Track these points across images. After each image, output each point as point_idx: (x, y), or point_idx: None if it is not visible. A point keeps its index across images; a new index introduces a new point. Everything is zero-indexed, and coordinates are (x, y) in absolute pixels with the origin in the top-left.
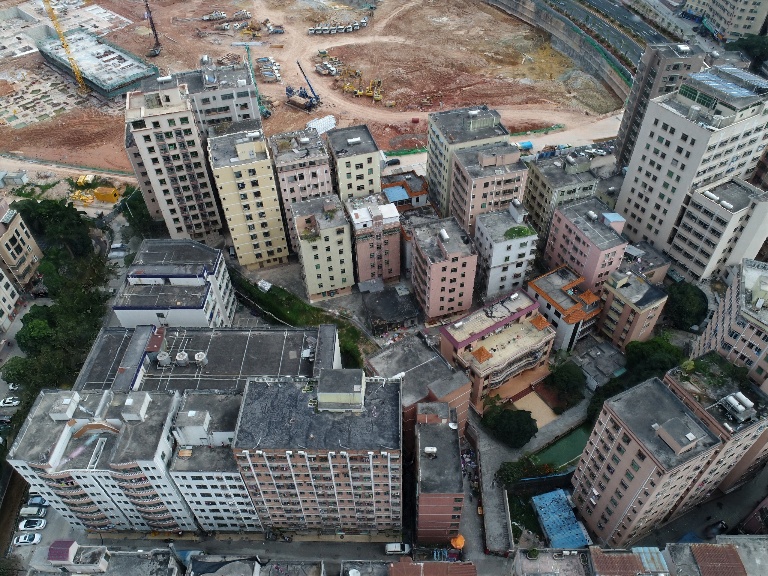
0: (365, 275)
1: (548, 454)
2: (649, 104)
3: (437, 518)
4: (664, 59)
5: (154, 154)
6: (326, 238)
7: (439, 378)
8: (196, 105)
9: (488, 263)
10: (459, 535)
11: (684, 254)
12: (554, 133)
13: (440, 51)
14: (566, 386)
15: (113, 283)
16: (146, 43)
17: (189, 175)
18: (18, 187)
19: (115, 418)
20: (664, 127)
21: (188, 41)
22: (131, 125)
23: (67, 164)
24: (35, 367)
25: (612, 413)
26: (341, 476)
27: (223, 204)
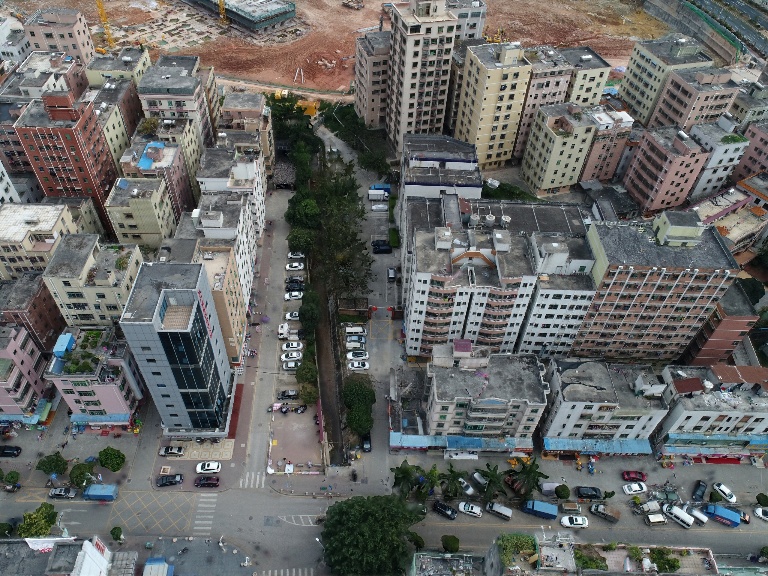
0: (587, 175)
1: None
2: None
3: (720, 344)
4: None
5: (416, 58)
6: (576, 136)
7: None
8: None
9: (703, 165)
10: None
11: None
12: None
13: (548, 8)
14: None
15: None
16: None
17: (435, 81)
18: None
19: (488, 248)
20: None
21: None
22: (409, 29)
23: None
24: None
25: None
26: (674, 297)
27: (482, 104)
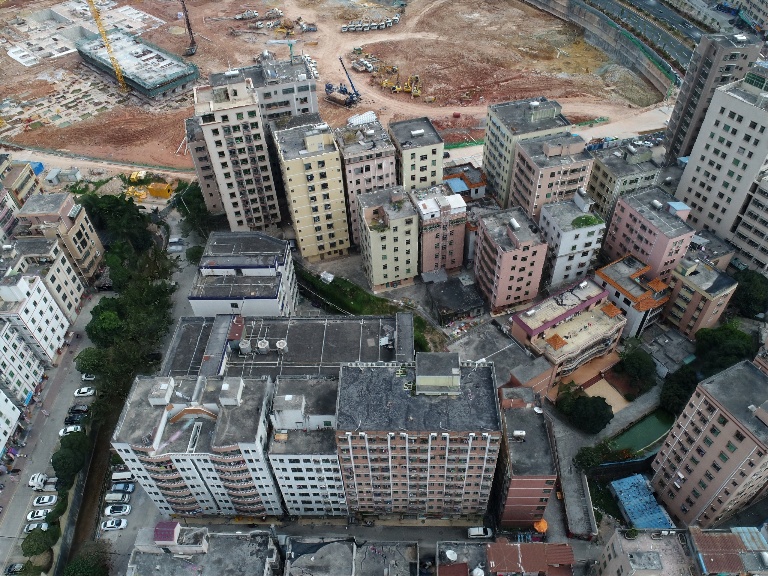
0: (429, 266)
1: (623, 440)
2: (715, 93)
3: (525, 501)
4: (721, 49)
5: (221, 148)
6: (395, 228)
7: (520, 364)
8: (258, 99)
9: (554, 252)
10: (541, 519)
11: (749, 242)
12: (599, 126)
13: (474, 47)
14: (638, 373)
15: (173, 276)
16: (181, 42)
17: (253, 168)
18: (72, 184)
19: (212, 403)
20: (731, 115)
21: (222, 40)
22: (201, 119)
23: (114, 161)
24: (110, 357)
25: (707, 395)
26: (437, 458)
27: (291, 196)
